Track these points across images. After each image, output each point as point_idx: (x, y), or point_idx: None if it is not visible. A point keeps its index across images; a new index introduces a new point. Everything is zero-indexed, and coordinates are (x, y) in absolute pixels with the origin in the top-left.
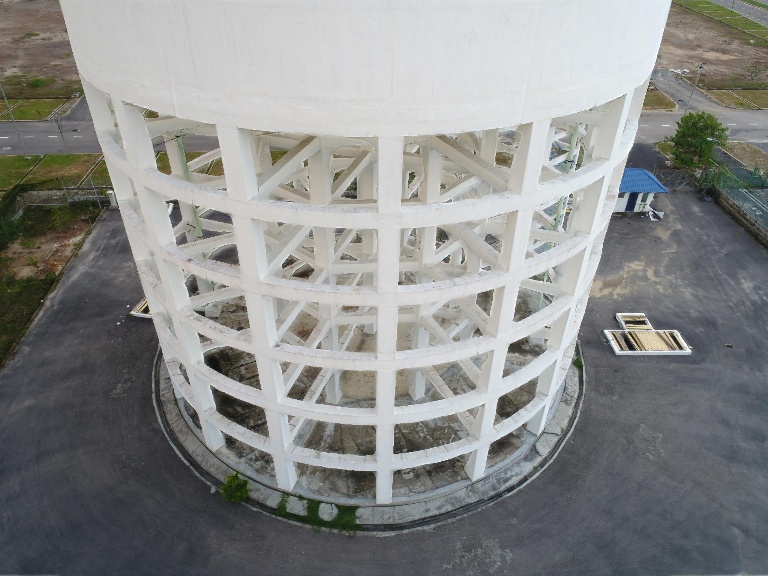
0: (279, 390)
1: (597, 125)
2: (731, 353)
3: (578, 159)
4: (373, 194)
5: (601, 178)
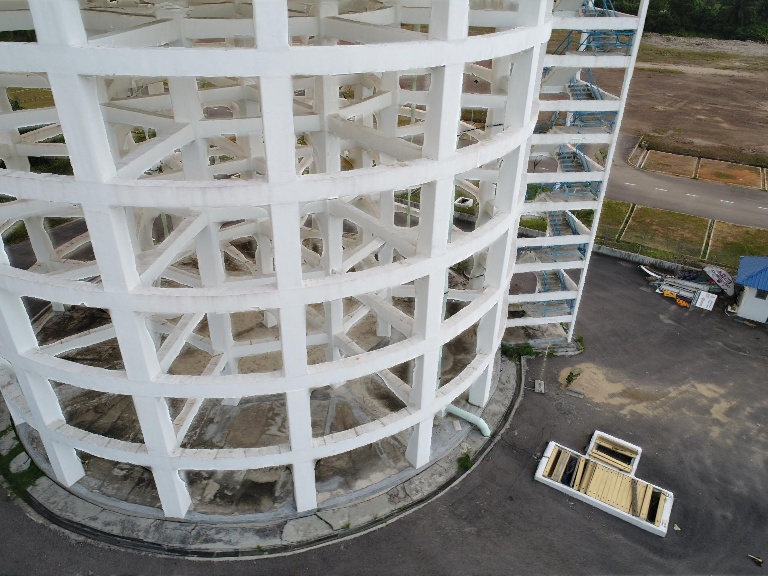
0: None
1: (512, 92)
2: (748, 573)
3: (761, 248)
4: (250, 142)
5: (255, 81)
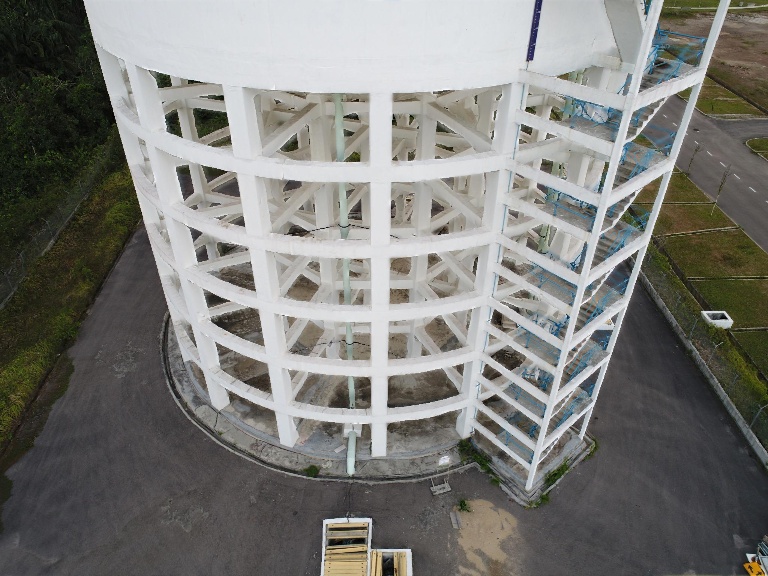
0: (196, 185)
1: None
2: None
3: None
4: None
5: None
